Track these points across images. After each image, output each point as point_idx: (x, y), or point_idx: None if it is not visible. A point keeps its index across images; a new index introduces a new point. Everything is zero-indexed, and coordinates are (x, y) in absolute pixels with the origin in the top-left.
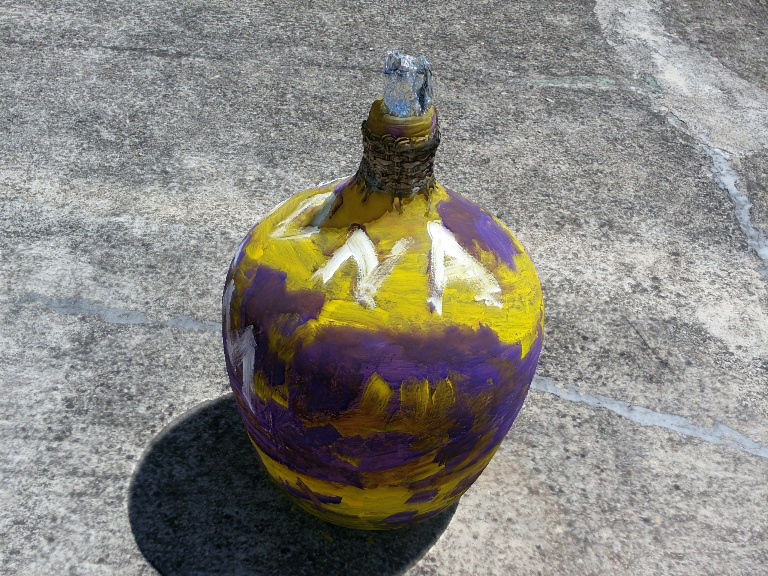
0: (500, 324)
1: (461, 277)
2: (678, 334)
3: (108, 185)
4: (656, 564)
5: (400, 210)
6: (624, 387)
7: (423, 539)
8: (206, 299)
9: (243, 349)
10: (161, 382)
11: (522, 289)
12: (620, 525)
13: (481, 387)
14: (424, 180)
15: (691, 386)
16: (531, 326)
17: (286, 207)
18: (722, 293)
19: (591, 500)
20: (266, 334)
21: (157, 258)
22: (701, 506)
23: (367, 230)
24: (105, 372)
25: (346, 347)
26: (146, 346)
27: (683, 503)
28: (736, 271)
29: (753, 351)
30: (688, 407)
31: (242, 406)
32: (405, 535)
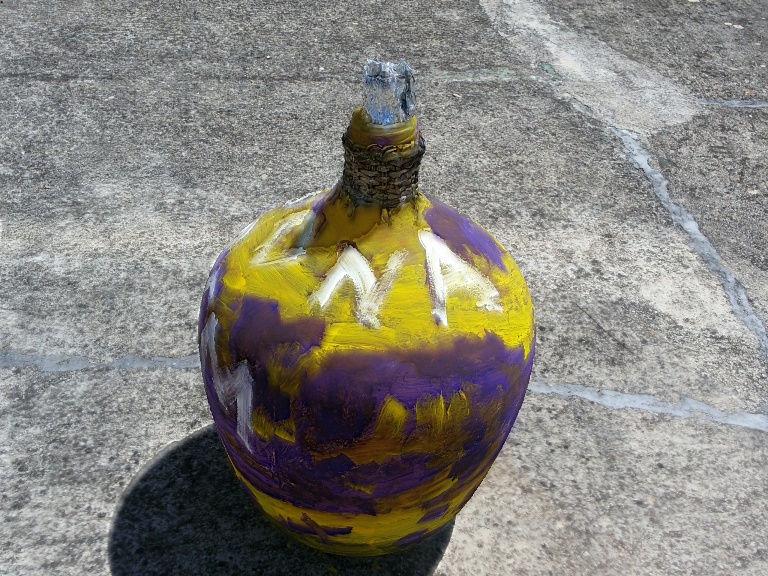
0: (503, 328)
1: (460, 284)
2: (628, 314)
3: (17, 223)
4: (658, 545)
5: (389, 221)
6: (590, 373)
7: (429, 556)
8: (150, 334)
9: (237, 386)
10: (119, 429)
11: (516, 289)
12: (616, 511)
13: (492, 395)
14: (410, 188)
15: (651, 364)
16: (528, 326)
17: (259, 230)
18: (659, 269)
19: (583, 490)
20: (264, 367)
21: (87, 296)
22: (687, 481)
23: (358, 246)
24: (55, 426)
25: (355, 371)
26: (95, 392)
27: (669, 480)
28: (667, 246)
29: (700, 322)
30: (653, 385)
31: (235, 446)
32: (410, 554)
